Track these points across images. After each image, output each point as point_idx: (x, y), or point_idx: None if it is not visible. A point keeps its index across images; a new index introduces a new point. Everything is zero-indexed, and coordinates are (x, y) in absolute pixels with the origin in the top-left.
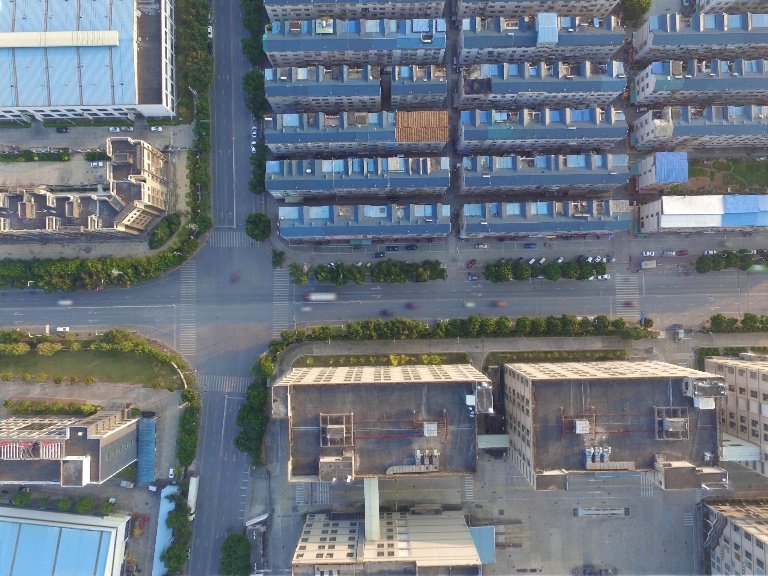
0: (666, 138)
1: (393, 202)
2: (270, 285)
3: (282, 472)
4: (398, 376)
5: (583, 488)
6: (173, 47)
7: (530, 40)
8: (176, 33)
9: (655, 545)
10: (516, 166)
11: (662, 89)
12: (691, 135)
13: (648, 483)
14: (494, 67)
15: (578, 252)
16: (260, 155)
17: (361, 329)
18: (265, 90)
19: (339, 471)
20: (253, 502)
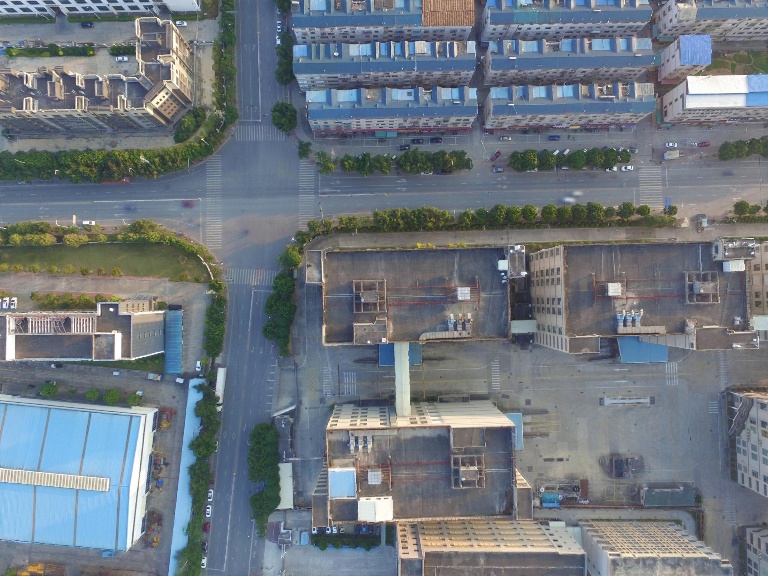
0: (689, 24)
1: None
2: (296, 179)
3: (309, 364)
4: None
5: (609, 377)
6: None
7: None
8: None
9: (681, 433)
10: (542, 49)
11: None
12: (714, 19)
13: (673, 372)
14: None
15: (601, 144)
16: (286, 45)
17: (388, 217)
18: None
19: (373, 334)
20: (280, 394)
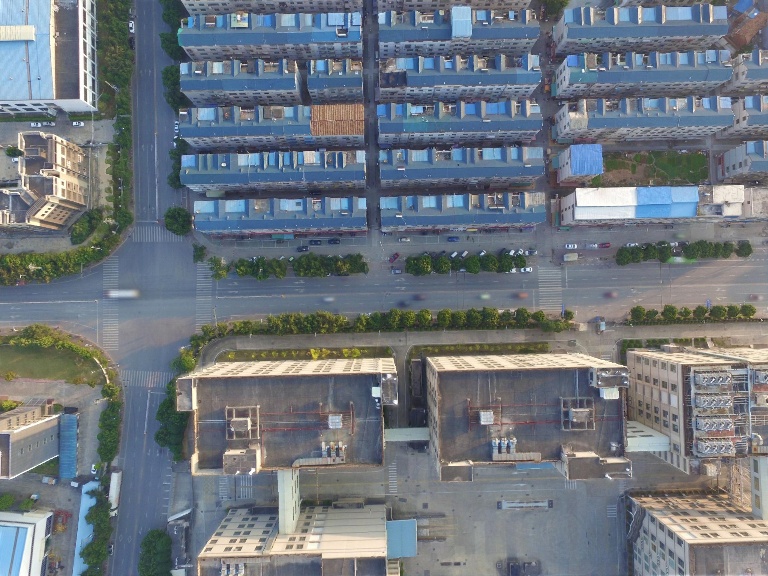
0: (583, 131)
1: (314, 196)
2: (193, 280)
3: None
4: (309, 369)
5: (507, 481)
6: (95, 42)
7: (445, 33)
8: (98, 28)
9: (579, 537)
10: (431, 159)
11: (577, 82)
12: (606, 127)
13: None
14: (410, 60)
15: (501, 245)
16: (180, 149)
17: (281, 323)
18: (180, 84)
19: (243, 464)
20: (176, 497)
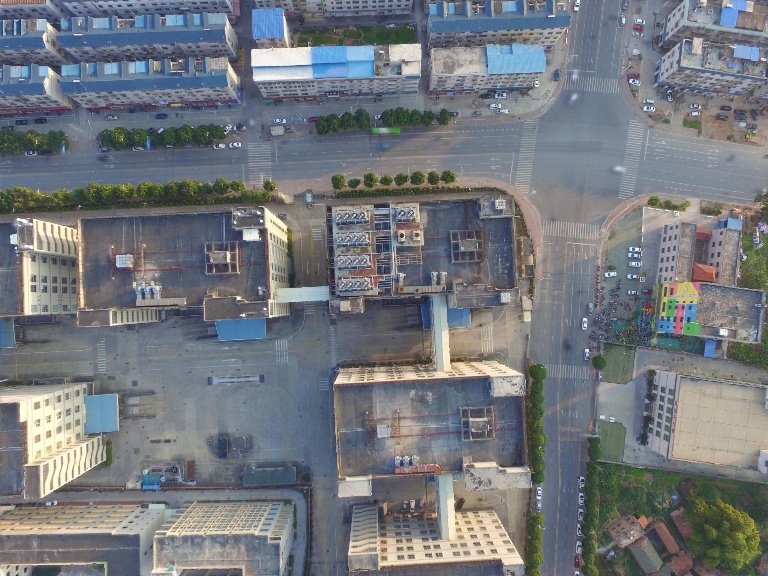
0: None
1: None
2: None
3: None
4: None
5: (217, 356)
6: None
7: None
8: None
9: (290, 411)
10: (111, 25)
11: None
12: None
13: (283, 349)
14: None
15: (210, 122)
16: None
17: None
18: None
19: None
20: None
